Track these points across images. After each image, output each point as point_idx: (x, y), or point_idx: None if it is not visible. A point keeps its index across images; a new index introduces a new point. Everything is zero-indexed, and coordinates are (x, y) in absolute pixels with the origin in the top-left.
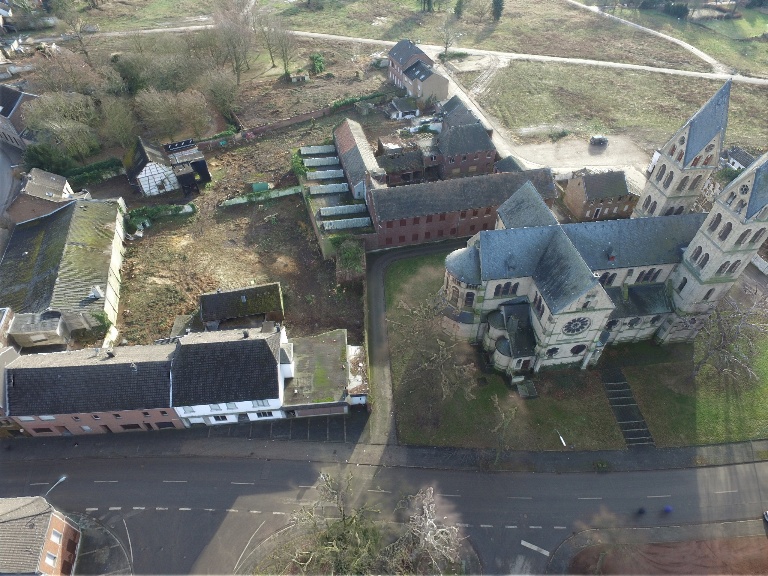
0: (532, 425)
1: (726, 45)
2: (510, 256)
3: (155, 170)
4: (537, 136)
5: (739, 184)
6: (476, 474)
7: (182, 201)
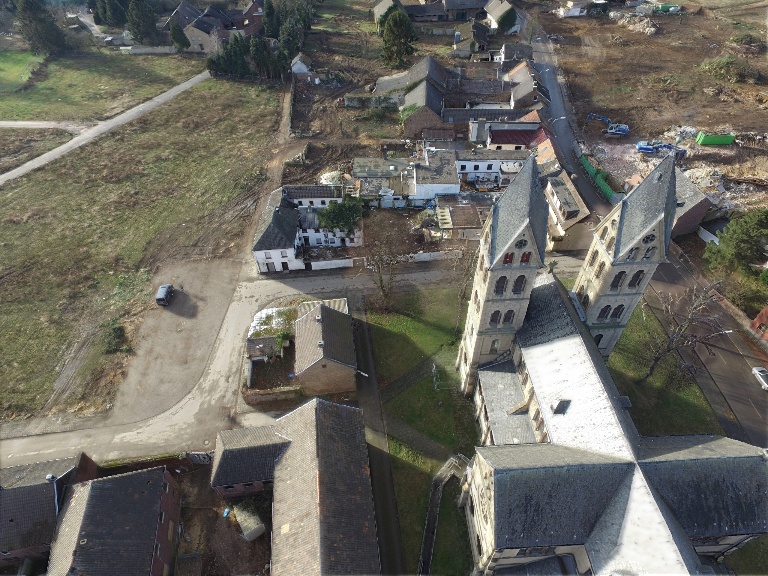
0: None
1: (22, 101)
2: (704, 574)
3: None
4: (98, 371)
5: None
6: None
7: None
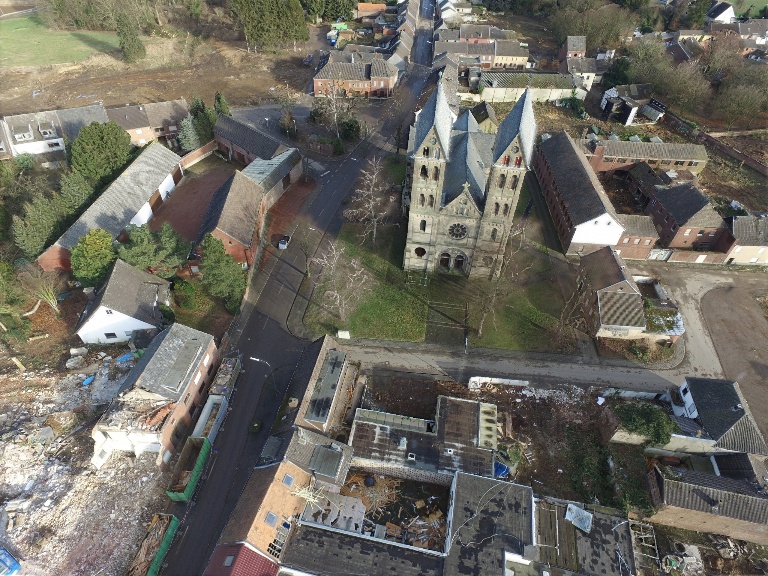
0: (377, 187)
1: None
2: (455, 127)
3: (613, 94)
4: None
5: None
6: None
7: (596, 116)
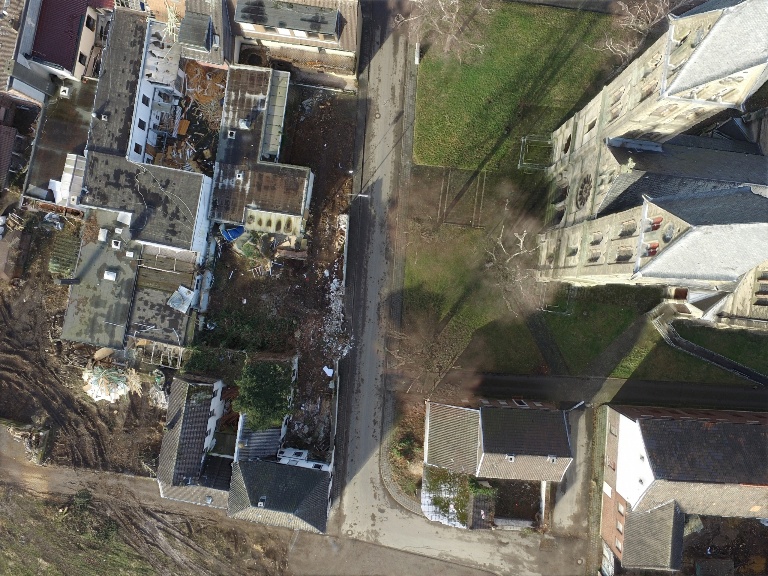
0: None
1: None
2: None
3: None
4: None
5: None
6: None
7: None
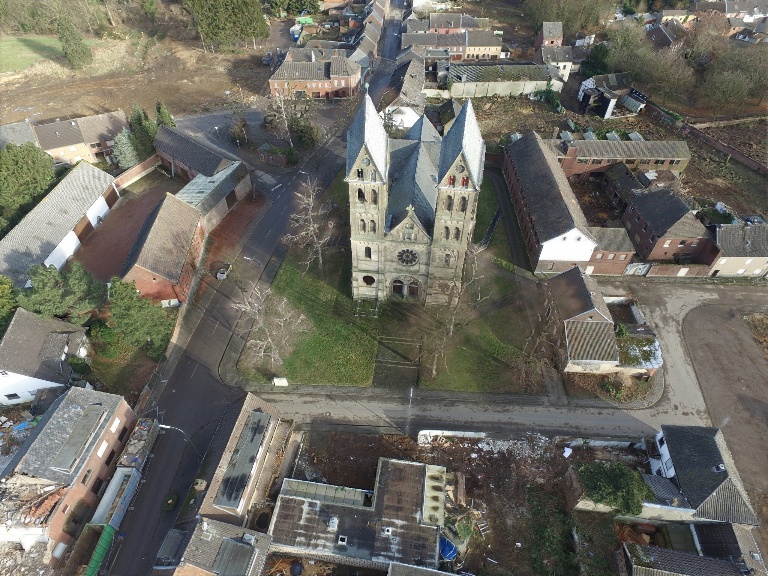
0: (332, 201)
1: None
2: None
3: (591, 85)
4: None
5: None
6: (319, 180)
7: (573, 109)
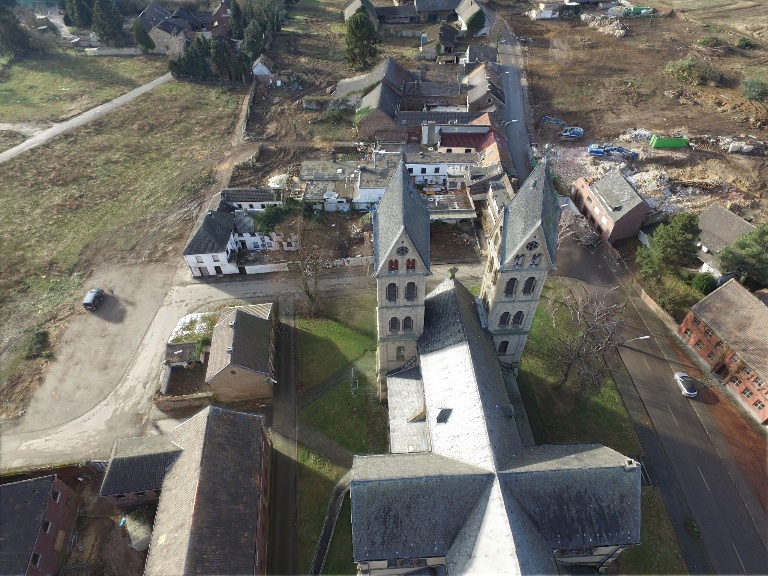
0: None
1: None
2: None
3: None
4: (15, 377)
5: (523, 245)
6: None
7: None
